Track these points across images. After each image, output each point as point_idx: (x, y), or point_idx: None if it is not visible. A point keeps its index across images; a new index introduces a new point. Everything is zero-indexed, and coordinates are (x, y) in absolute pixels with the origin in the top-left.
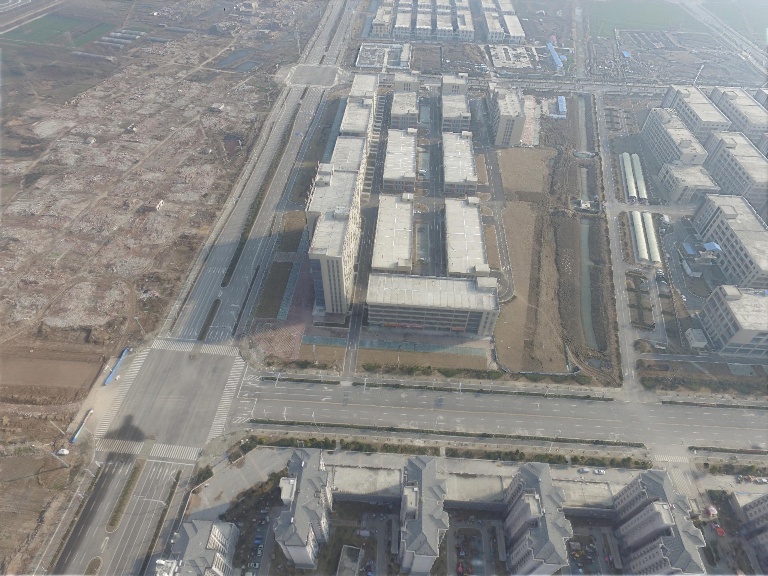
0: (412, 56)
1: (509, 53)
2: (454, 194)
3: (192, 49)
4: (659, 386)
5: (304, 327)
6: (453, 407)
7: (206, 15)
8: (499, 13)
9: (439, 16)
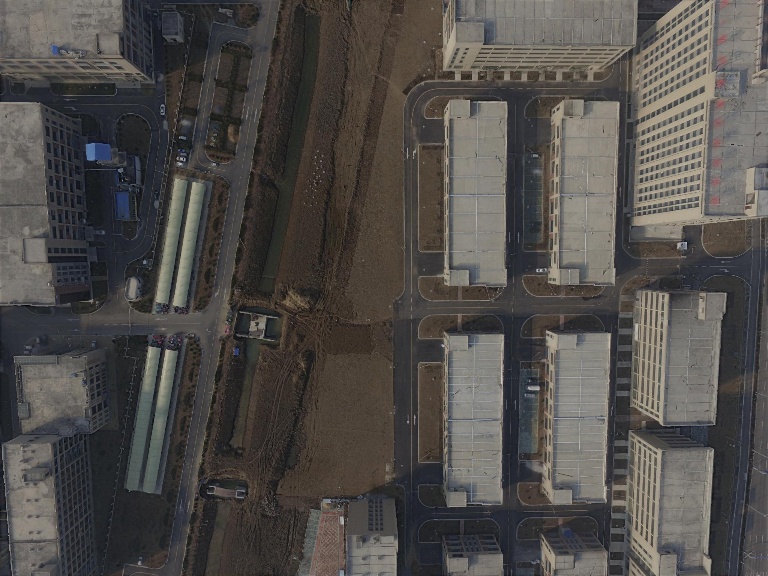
0: None
1: None
2: (480, 328)
3: None
4: None
5: None
6: None
7: None
8: None
9: None
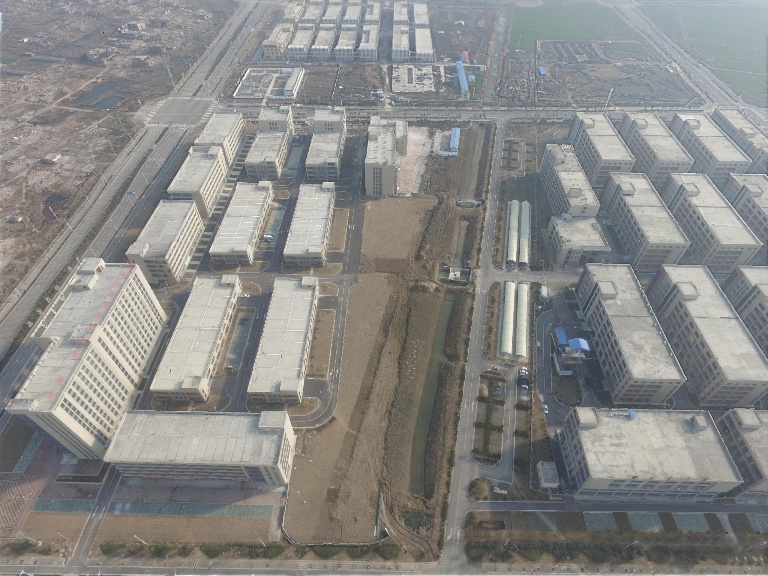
0: (302, 82)
1: (413, 74)
2: (298, 267)
3: (51, 83)
4: (487, 556)
5: (43, 484)
6: None
7: (87, 39)
8: (411, 26)
9: (343, 32)
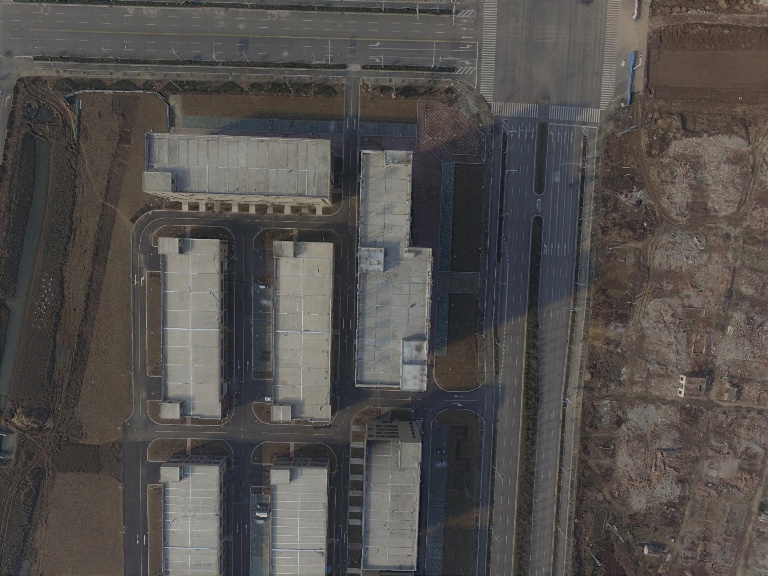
0: None
1: None
2: (209, 453)
3: None
4: None
5: (417, 150)
6: (227, 40)
7: None
8: None
9: None
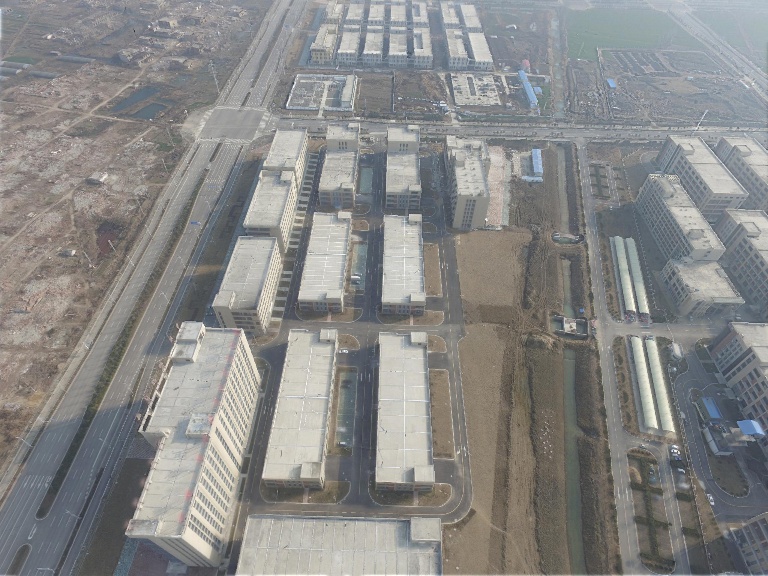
0: (357, 91)
1: (474, 84)
2: (395, 315)
3: (84, 87)
4: None
5: None
6: None
7: (114, 36)
8: (463, 30)
9: (392, 35)
